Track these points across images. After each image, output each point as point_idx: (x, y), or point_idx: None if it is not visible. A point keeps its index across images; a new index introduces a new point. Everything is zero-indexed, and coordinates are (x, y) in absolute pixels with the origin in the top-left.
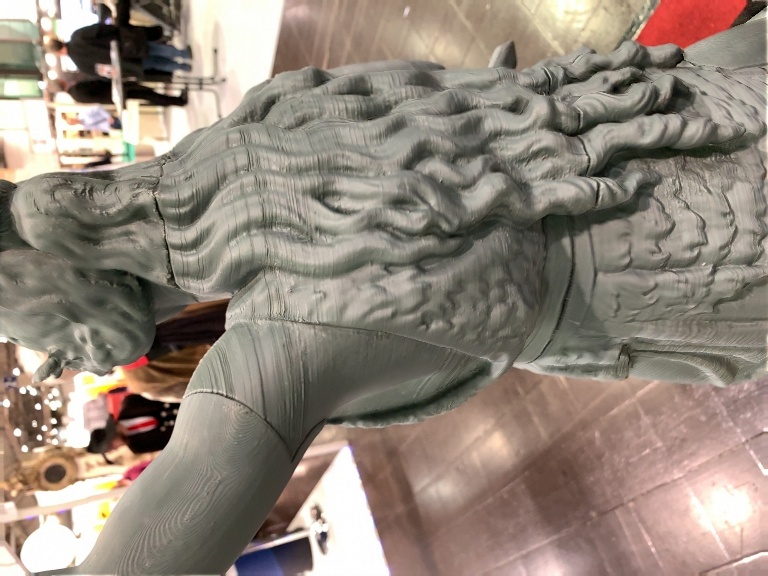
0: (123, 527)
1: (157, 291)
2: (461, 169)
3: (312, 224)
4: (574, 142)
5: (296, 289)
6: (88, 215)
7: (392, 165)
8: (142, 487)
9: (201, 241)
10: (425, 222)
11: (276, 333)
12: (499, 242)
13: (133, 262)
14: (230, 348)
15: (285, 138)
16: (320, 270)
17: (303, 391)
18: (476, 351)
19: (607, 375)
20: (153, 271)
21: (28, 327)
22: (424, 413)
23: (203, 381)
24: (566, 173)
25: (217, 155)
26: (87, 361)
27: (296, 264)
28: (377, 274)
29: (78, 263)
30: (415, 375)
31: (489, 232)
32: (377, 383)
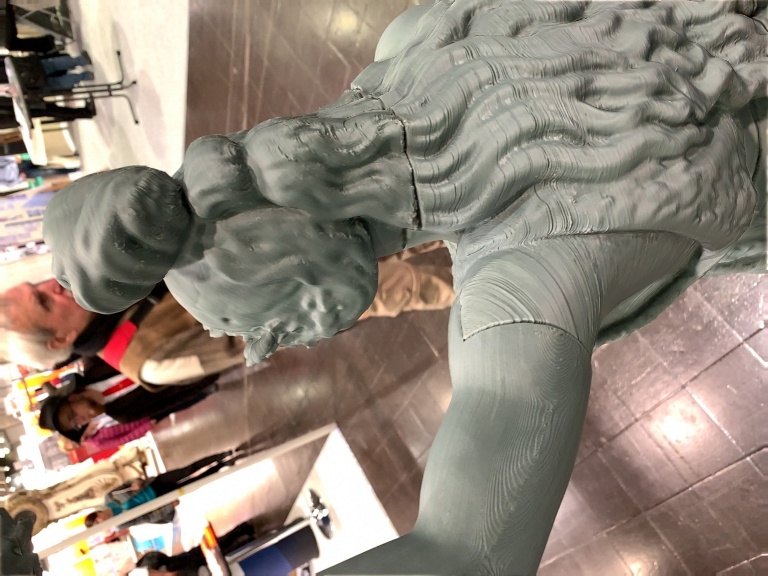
0: (470, 477)
1: (375, 240)
2: (688, 56)
3: (584, 127)
4: (755, 23)
5: (580, 198)
6: (336, 157)
7: (637, 57)
8: (470, 433)
9: (456, 168)
10: (688, 110)
11: (560, 250)
12: (730, 128)
13: (378, 204)
14: (512, 275)
15: (521, 45)
16: (607, 173)
17: (599, 305)
18: (722, 243)
19: (763, 265)
20: (398, 212)
21: (255, 300)
22: (635, 326)
23: (492, 315)
24: (757, 55)
25: (446, 75)
26: (308, 330)
27: (582, 170)
28: (655, 170)
29: (319, 215)
30: (650, 282)
31: (718, 119)
32: (630, 293)
